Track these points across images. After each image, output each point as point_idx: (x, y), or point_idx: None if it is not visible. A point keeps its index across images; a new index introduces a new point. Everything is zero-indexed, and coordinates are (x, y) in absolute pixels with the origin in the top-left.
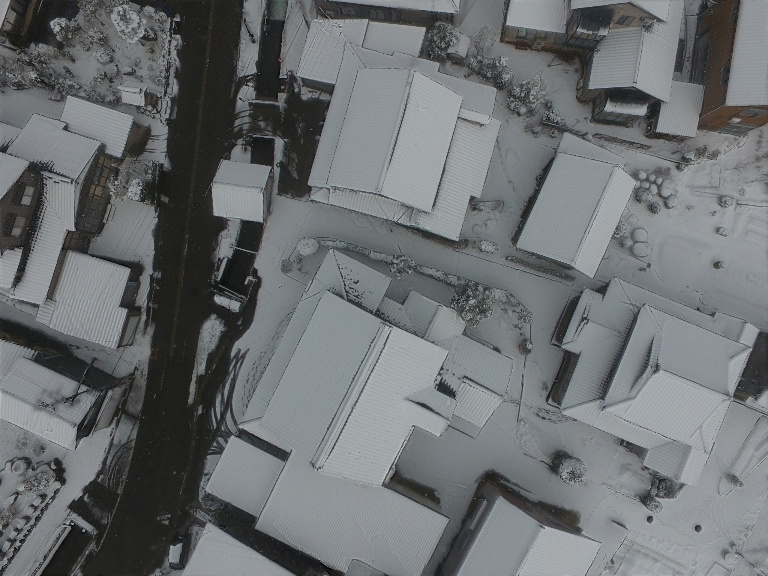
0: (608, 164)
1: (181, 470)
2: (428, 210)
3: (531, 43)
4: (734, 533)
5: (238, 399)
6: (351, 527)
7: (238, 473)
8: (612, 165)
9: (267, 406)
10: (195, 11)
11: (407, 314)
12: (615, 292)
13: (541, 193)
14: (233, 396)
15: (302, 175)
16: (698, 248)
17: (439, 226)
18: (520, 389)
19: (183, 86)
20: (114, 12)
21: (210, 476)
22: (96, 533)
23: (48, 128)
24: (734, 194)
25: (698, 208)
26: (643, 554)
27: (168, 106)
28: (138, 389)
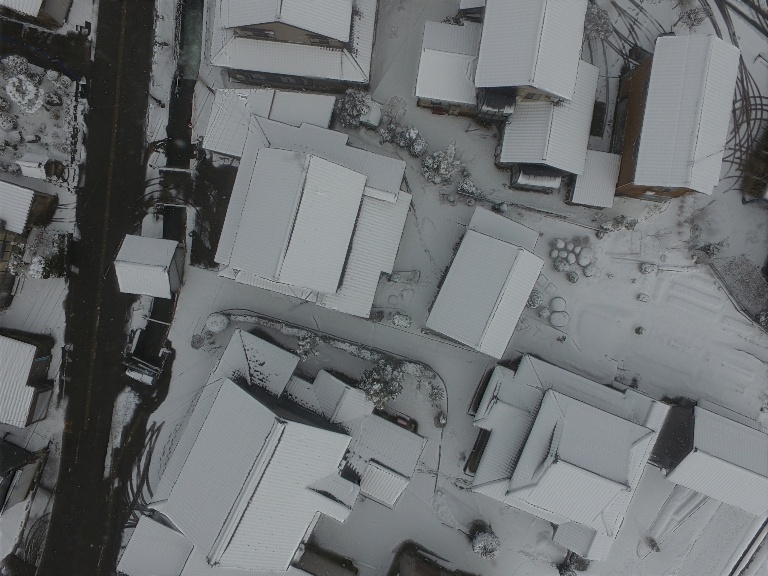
0: (514, 246)
1: (98, 543)
2: (332, 293)
3: (447, 109)
4: None
5: (154, 472)
6: None
7: (149, 552)
8: (517, 247)
9: (170, 493)
10: (102, 74)
11: (316, 394)
12: (525, 370)
13: (450, 271)
14: (149, 469)
15: (215, 245)
16: (617, 316)
17: (347, 305)
18: (437, 459)
19: (91, 153)
20: (9, 83)
21: (122, 554)
22: None
23: None
24: (655, 260)
25: (619, 275)
26: None
27: (76, 174)
28: (53, 463)
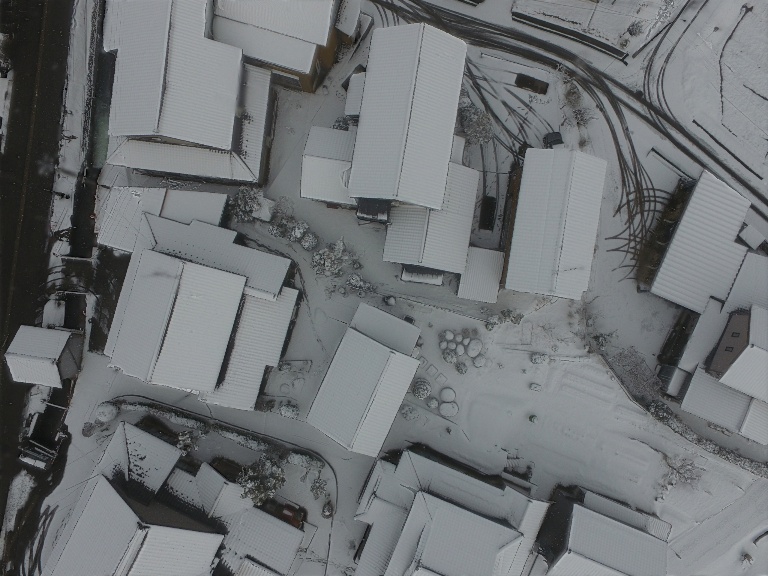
0: (386, 348)
1: None
2: (210, 390)
3: (339, 204)
4: None
5: (46, 556)
6: None
7: None
8: (390, 350)
9: None
10: (11, 165)
11: (197, 487)
12: (405, 466)
13: (330, 368)
14: (41, 553)
15: None
16: (508, 406)
17: (230, 399)
18: (327, 548)
19: None
20: None
21: None
22: None
23: None
24: (547, 350)
25: (510, 364)
26: None
27: None
28: None
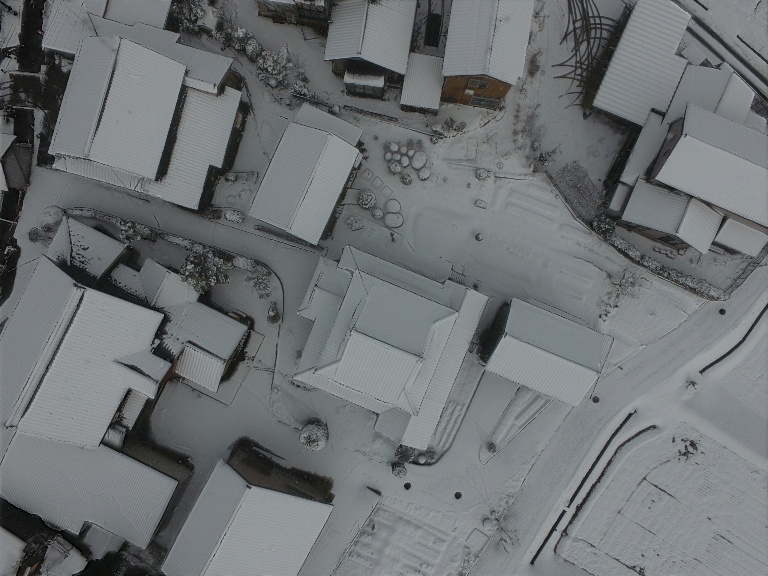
0: (324, 132)
1: None
2: (151, 177)
3: (284, 16)
4: (495, 500)
5: None
6: (65, 487)
7: None
8: (327, 133)
9: None
10: None
11: (141, 281)
12: (346, 259)
13: (272, 162)
14: None
15: None
16: (453, 220)
17: (173, 194)
18: (274, 357)
19: None
20: None
21: None
22: None
23: None
24: (492, 167)
25: (456, 181)
26: (405, 520)
27: None
28: None
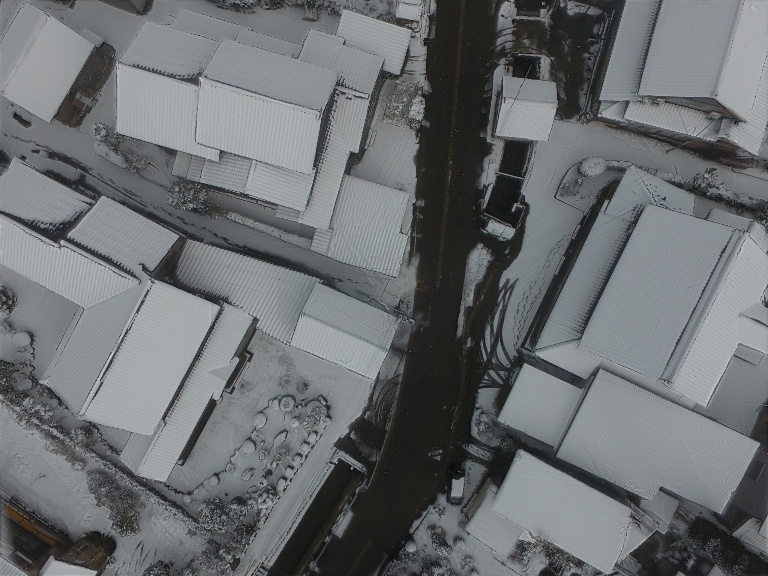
0: None
1: (451, 404)
2: (747, 119)
3: None
4: None
5: (508, 330)
6: (678, 449)
7: (532, 402)
8: None
9: (586, 327)
10: None
11: None
12: None
13: None
14: (503, 328)
15: (571, 95)
16: None
17: (745, 139)
18: None
19: (441, 3)
20: None
21: None
22: (365, 470)
23: (329, 43)
24: None
25: None
26: None
27: (426, 25)
28: None
